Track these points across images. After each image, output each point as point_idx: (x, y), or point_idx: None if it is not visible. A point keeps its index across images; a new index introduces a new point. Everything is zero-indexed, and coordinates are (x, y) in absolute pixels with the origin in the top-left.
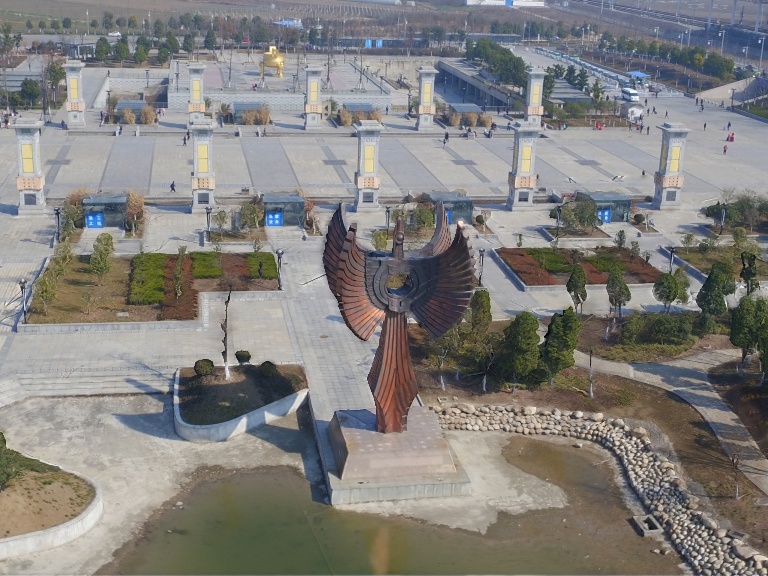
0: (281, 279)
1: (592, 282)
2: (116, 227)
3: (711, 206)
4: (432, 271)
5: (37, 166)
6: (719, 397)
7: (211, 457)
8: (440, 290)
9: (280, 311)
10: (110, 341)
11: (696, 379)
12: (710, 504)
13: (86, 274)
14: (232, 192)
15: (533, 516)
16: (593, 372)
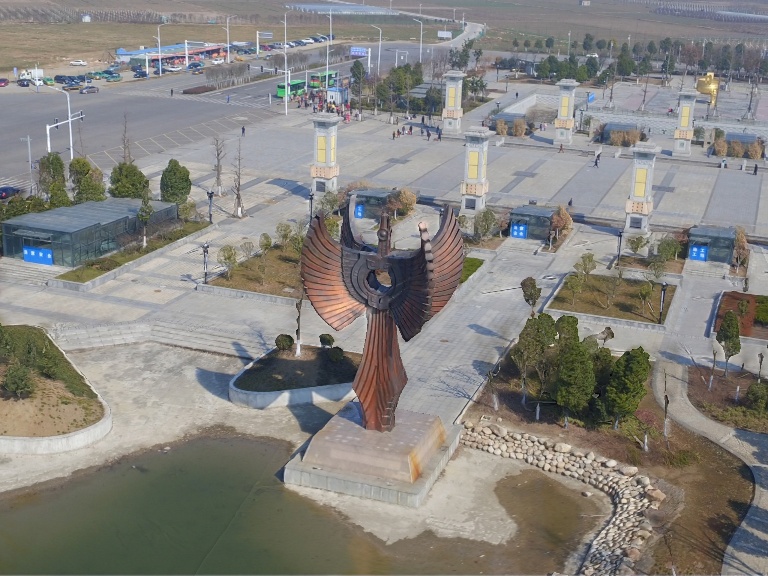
0: (466, 285)
1: None
2: (373, 219)
3: None
4: (407, 272)
5: (330, 157)
6: None
7: (235, 419)
8: (413, 292)
9: None
10: (258, 310)
11: None
12: None
13: None
14: (521, 204)
15: (455, 543)
16: (683, 428)
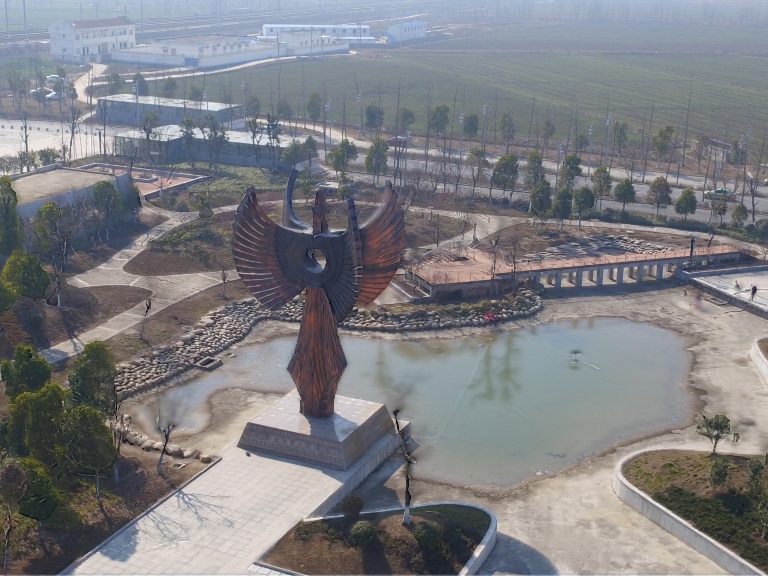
0: None
1: None
2: None
3: None
4: None
5: None
6: None
7: None
8: None
9: None
10: None
11: None
12: (160, 344)
13: None
14: None
15: (270, 390)
16: None
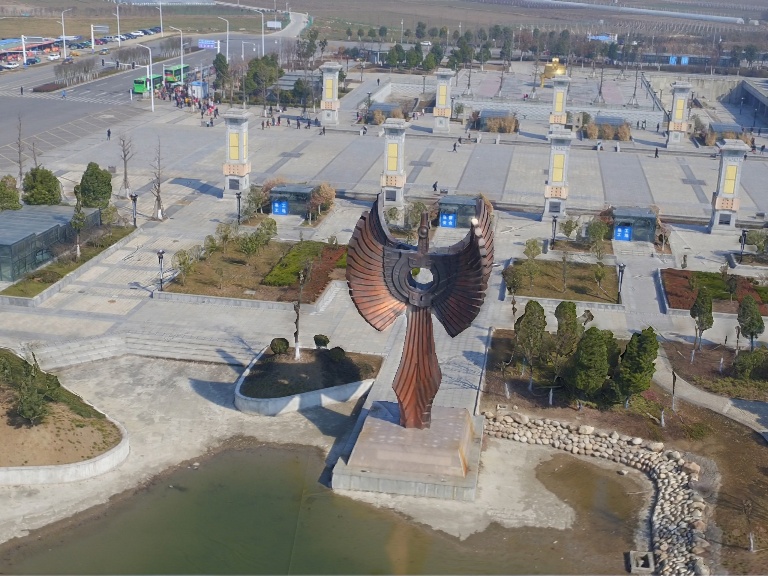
0: (420, 276)
1: None
2: (298, 215)
3: None
4: (452, 268)
5: (242, 154)
6: None
7: (251, 428)
8: (459, 288)
9: None
10: (226, 315)
11: None
12: (719, 552)
13: (244, 254)
14: (432, 193)
15: (525, 532)
16: (684, 402)
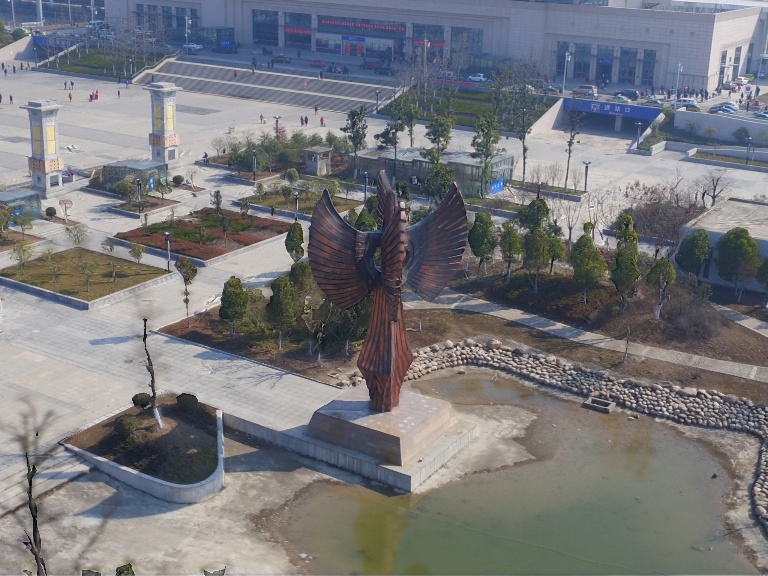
0: None
1: (248, 243)
2: None
3: (232, 156)
4: (423, 237)
5: None
6: (487, 302)
7: (243, 506)
8: (430, 254)
9: (33, 353)
10: None
11: (451, 294)
12: (616, 373)
13: None
14: None
15: (535, 432)
16: None
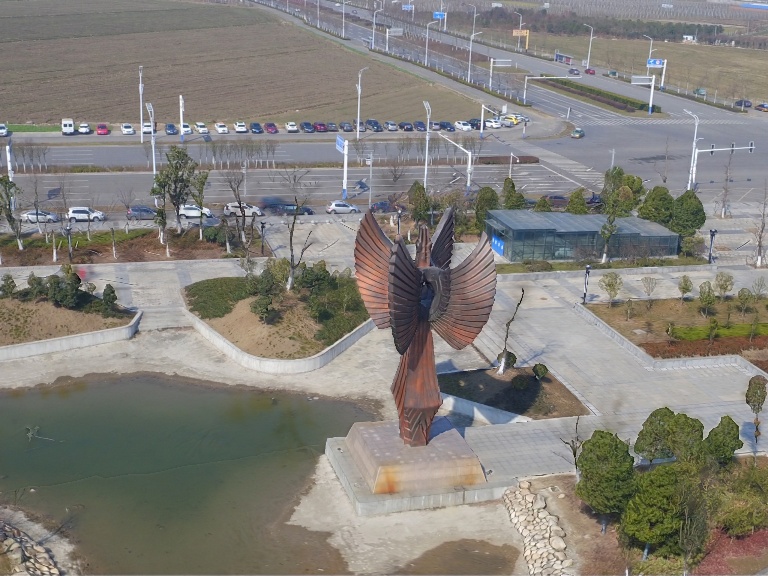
0: None
1: None
2: None
3: None
4: None
5: None
6: None
7: None
8: None
9: (742, 398)
10: (585, 338)
11: None
12: None
13: (734, 310)
14: None
15: (326, 551)
16: None
